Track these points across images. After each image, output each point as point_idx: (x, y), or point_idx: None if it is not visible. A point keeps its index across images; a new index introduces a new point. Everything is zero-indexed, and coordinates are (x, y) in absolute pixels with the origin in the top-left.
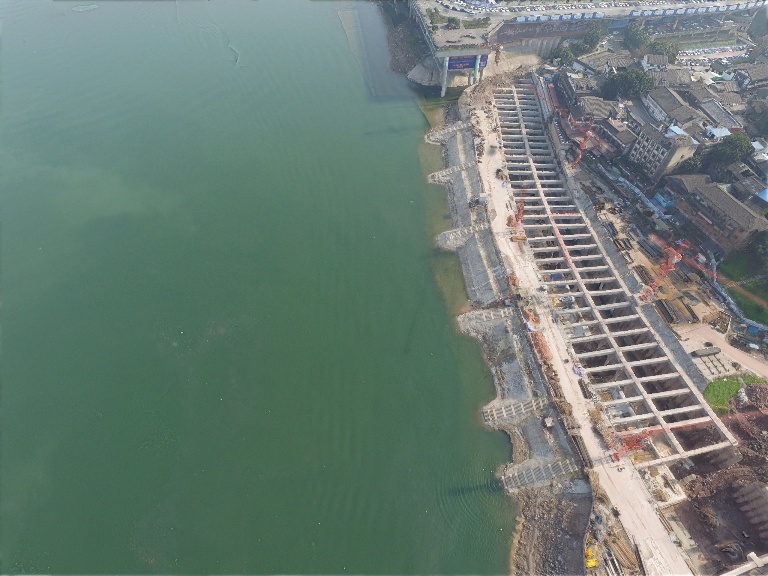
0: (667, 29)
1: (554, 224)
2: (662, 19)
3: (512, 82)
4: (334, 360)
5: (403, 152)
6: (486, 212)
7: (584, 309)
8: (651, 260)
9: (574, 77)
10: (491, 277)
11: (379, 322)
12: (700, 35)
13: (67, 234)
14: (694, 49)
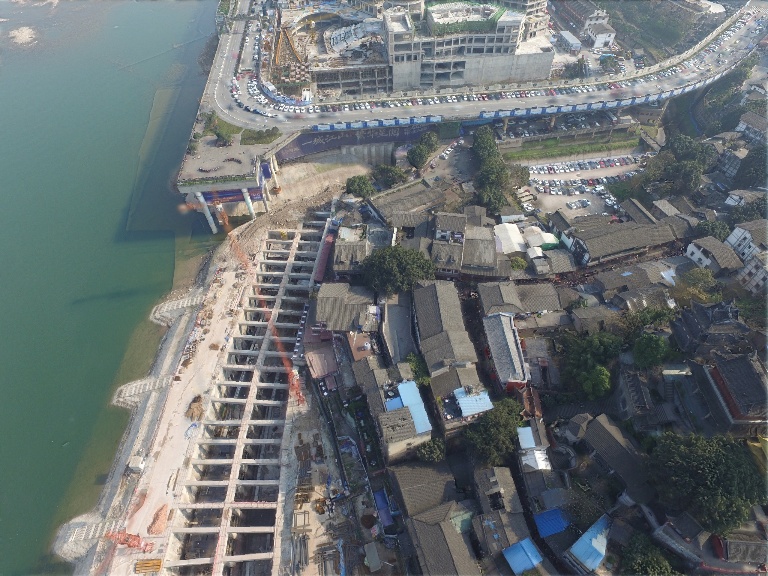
0: (542, 128)
1: (224, 528)
2: None
3: (302, 218)
4: None
5: (107, 339)
6: (131, 495)
7: None
8: None
9: (347, 236)
10: None
11: None
12: (587, 135)
13: None
14: (579, 153)
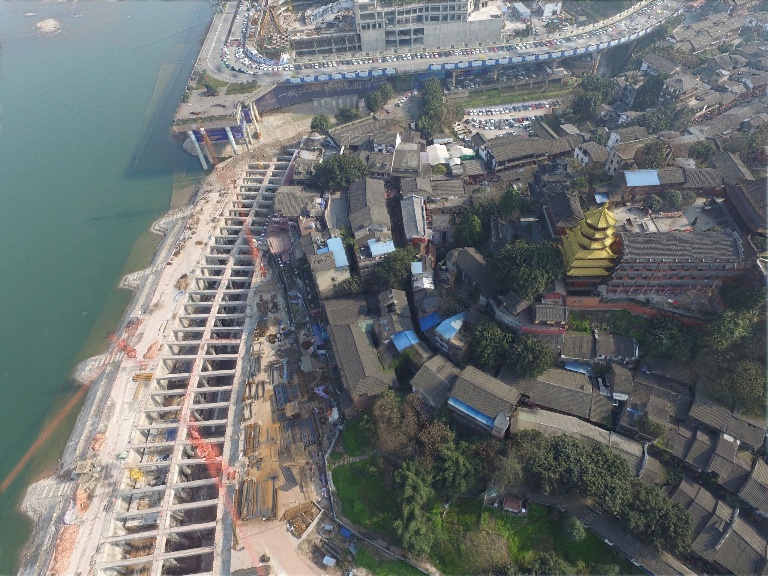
0: (486, 80)
1: (200, 355)
2: (486, 68)
3: (276, 153)
4: None
5: (117, 245)
6: (132, 336)
7: (156, 489)
8: (274, 415)
9: (306, 156)
10: (85, 432)
11: None
12: (526, 86)
13: None
14: (520, 102)
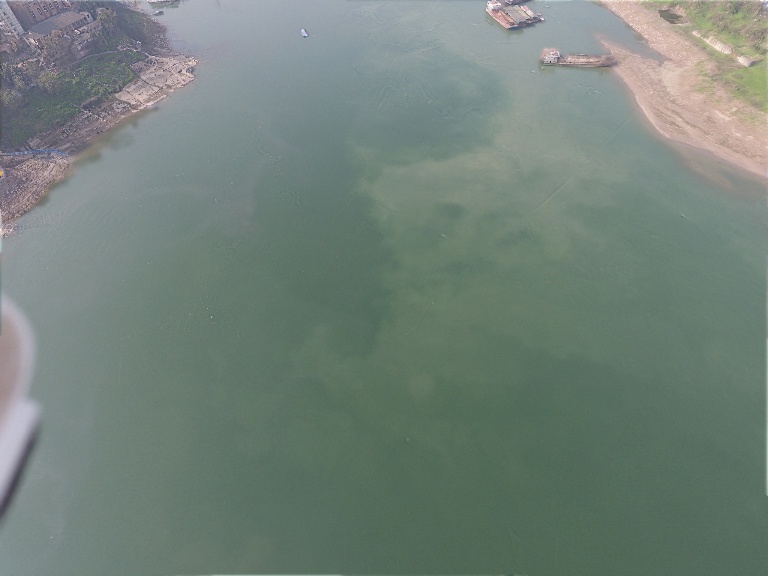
0: None
1: None
2: None
3: None
4: (84, 298)
5: None
6: None
7: None
8: None
9: None
10: None
11: (27, 335)
12: None
13: (382, 465)
14: None
